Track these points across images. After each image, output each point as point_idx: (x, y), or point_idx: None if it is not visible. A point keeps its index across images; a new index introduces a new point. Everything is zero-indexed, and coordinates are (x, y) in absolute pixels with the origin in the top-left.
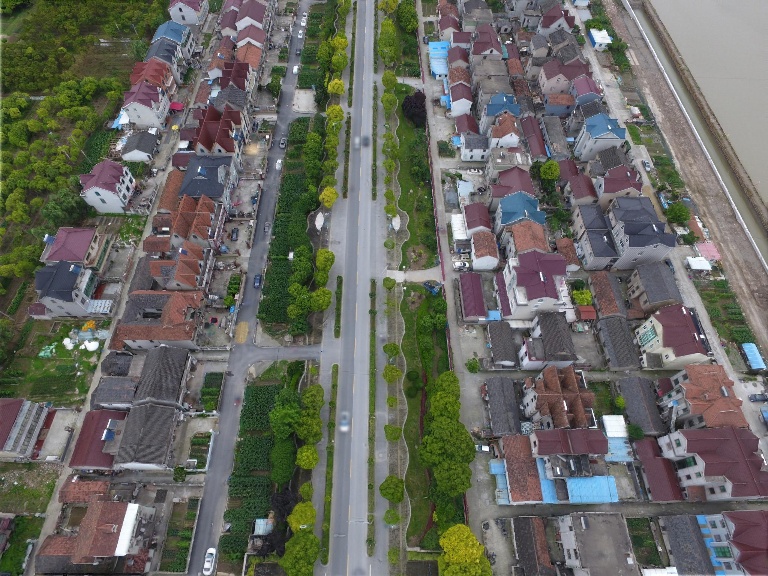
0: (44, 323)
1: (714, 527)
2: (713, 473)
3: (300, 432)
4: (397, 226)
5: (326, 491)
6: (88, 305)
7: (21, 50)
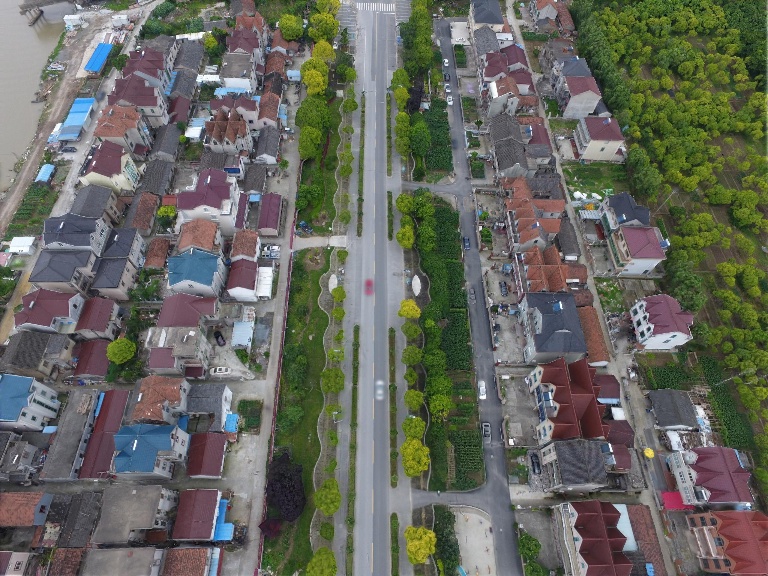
0: None
1: None
2: None
3: None
4: (333, 279)
5: None
6: None
7: None
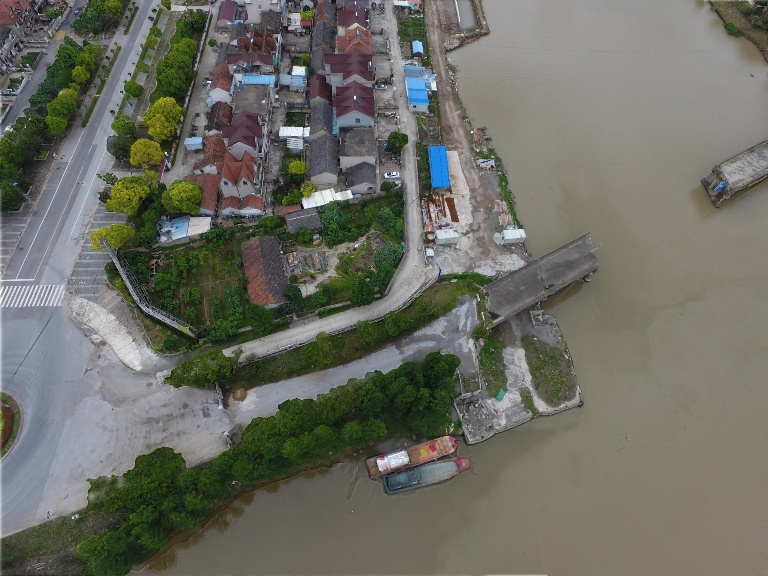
0: None
1: None
2: (336, 71)
3: (77, 61)
4: None
5: (94, 98)
6: None
7: None
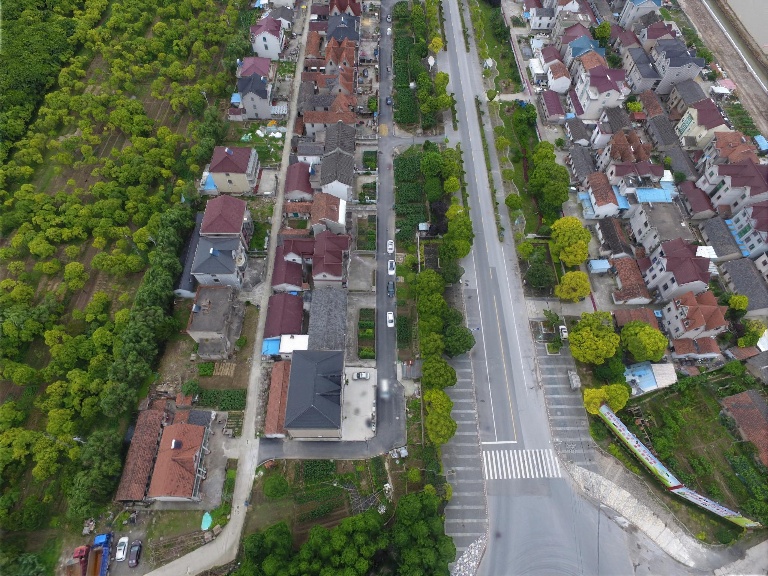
0: (238, 123)
1: (738, 222)
2: (737, 185)
3: (446, 170)
4: (490, 64)
5: (465, 209)
6: (271, 109)
7: None
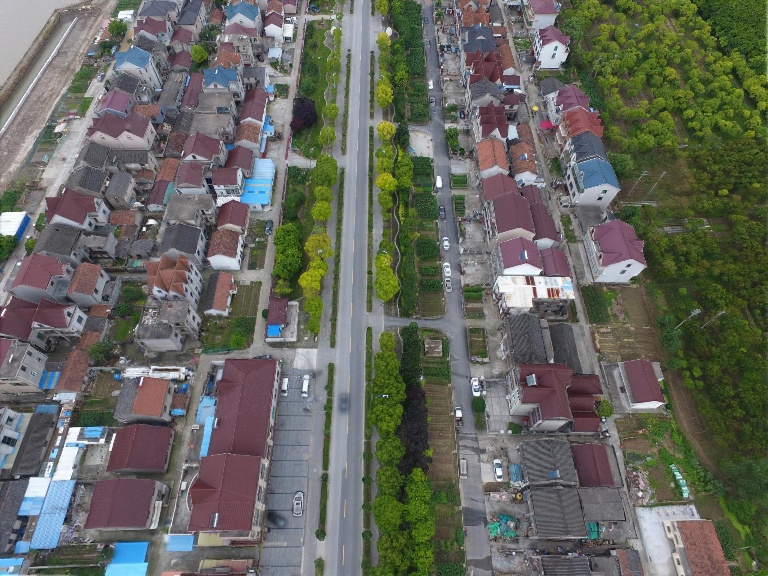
0: None
1: None
2: None
3: None
4: (333, 28)
5: None
6: None
7: (767, 187)
